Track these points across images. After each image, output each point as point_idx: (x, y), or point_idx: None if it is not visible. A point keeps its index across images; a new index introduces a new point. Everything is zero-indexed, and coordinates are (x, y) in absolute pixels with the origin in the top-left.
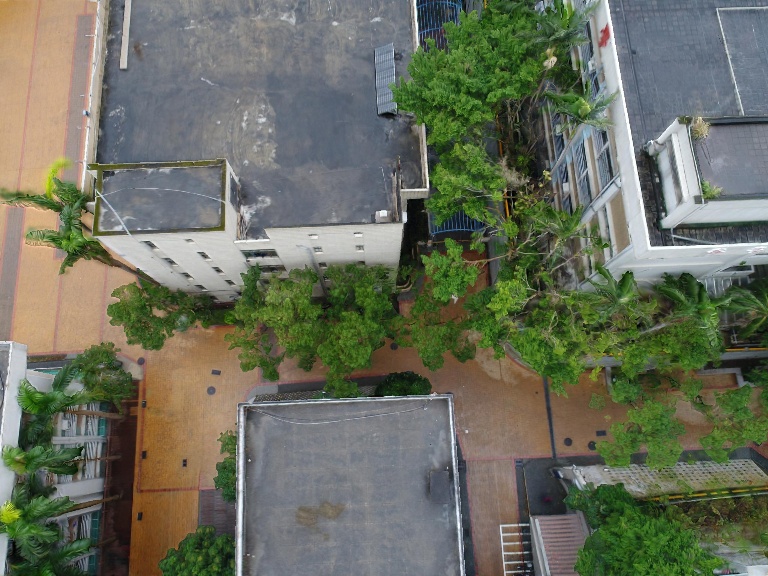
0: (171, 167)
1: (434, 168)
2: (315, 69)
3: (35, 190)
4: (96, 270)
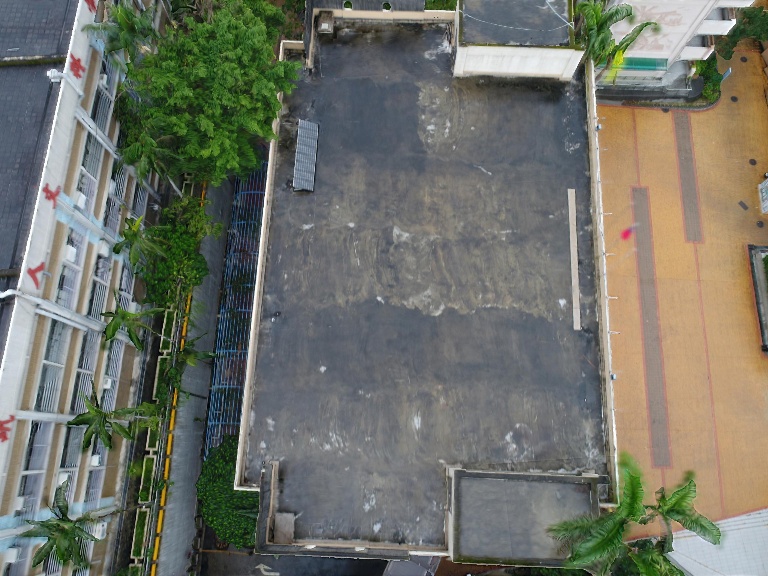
0: (509, 45)
1: (273, 44)
2: (376, 176)
3: (680, 257)
4: (606, 173)
